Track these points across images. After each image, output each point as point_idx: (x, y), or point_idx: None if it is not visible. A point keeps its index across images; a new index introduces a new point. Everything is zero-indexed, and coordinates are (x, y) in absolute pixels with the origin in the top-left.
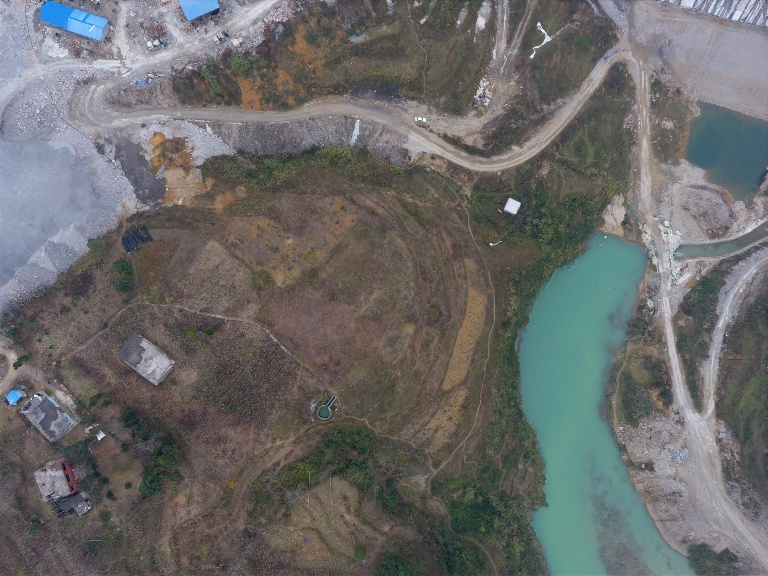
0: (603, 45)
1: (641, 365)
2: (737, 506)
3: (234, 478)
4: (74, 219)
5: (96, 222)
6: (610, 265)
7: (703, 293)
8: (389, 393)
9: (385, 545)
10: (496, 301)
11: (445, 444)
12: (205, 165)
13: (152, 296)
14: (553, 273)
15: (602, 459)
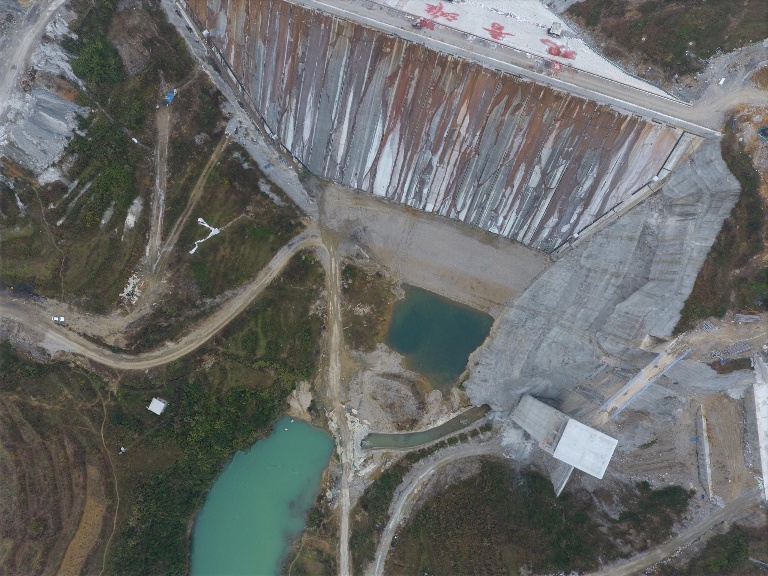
0: (284, 234)
1: (315, 557)
2: None
3: None
4: None
5: None
6: (298, 449)
7: (381, 489)
8: None
9: None
10: (119, 510)
11: None
12: None
13: None
14: None
15: None
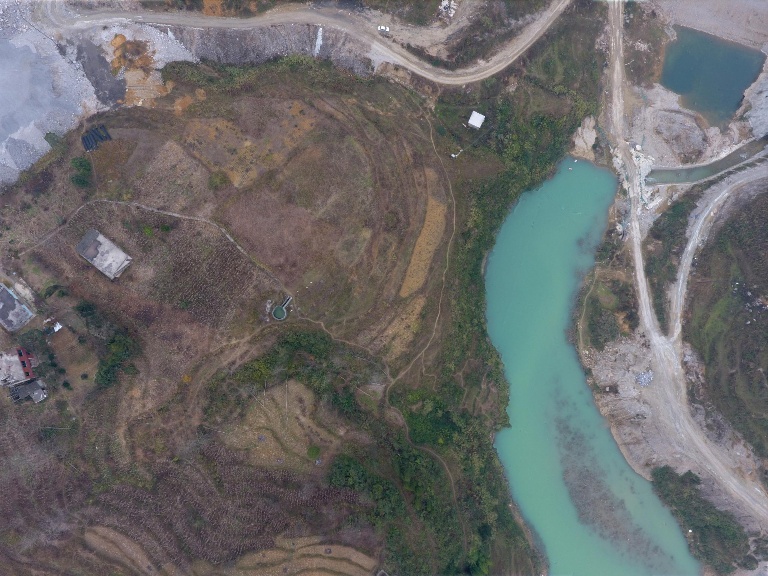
0: None
1: (609, 289)
2: (701, 428)
3: (189, 374)
4: (34, 116)
5: (56, 121)
6: (580, 190)
7: (673, 217)
8: (345, 297)
9: (339, 448)
10: (456, 211)
11: (403, 353)
12: (166, 68)
13: (110, 193)
14: (523, 198)
15: (567, 383)
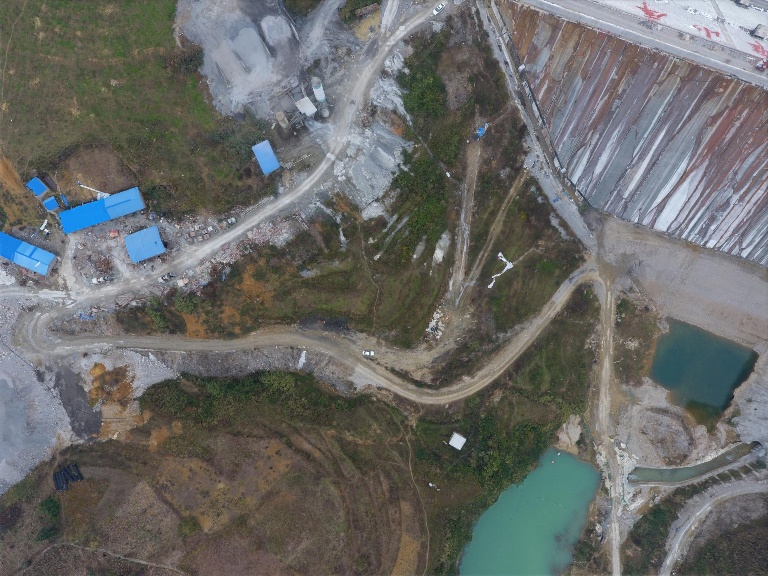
0: (568, 268)
1: None
2: None
3: None
4: (6, 455)
5: (29, 456)
6: (562, 481)
7: (654, 524)
8: None
9: None
10: (430, 546)
11: None
12: (144, 398)
13: (77, 538)
14: None
15: None
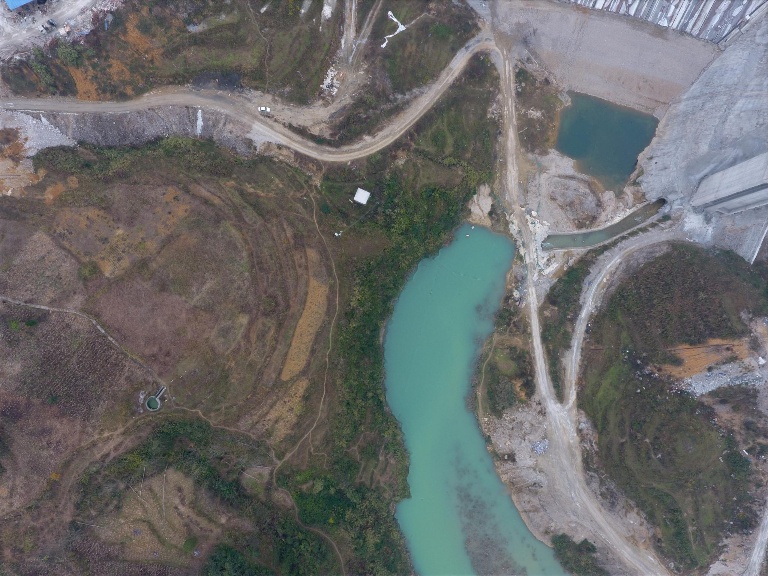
0: (463, 34)
1: (507, 356)
2: (595, 496)
3: (58, 470)
4: None
5: None
6: (479, 256)
7: (568, 283)
8: (223, 384)
9: (220, 537)
10: (339, 291)
11: (287, 435)
12: (37, 156)
13: None
14: (423, 264)
15: (468, 450)
